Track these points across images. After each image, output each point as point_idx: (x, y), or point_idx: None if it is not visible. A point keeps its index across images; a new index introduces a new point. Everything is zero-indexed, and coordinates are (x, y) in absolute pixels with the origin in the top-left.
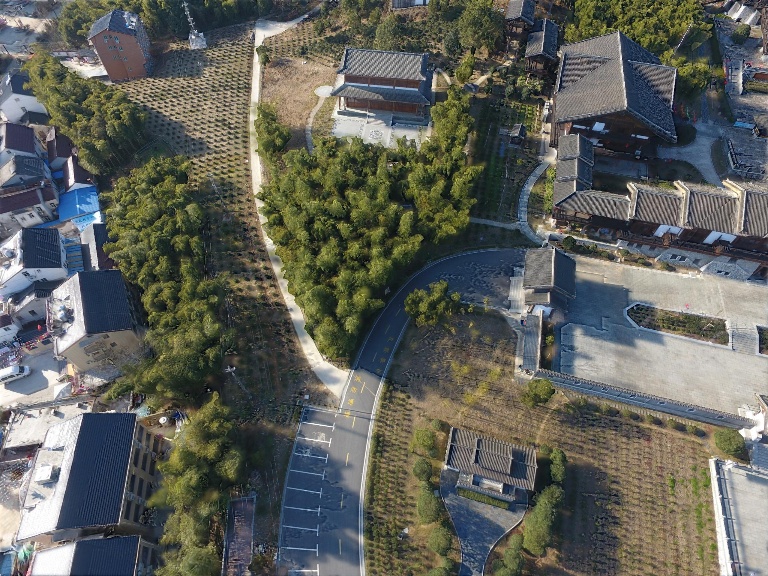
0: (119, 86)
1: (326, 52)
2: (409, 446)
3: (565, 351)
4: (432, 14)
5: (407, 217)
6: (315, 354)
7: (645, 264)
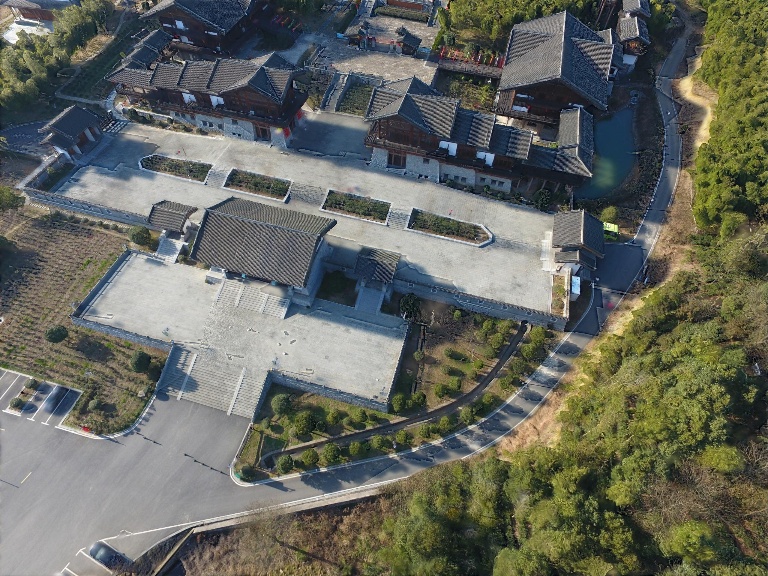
0: None
1: None
2: None
3: (69, 182)
4: None
5: None
6: None
7: (187, 130)
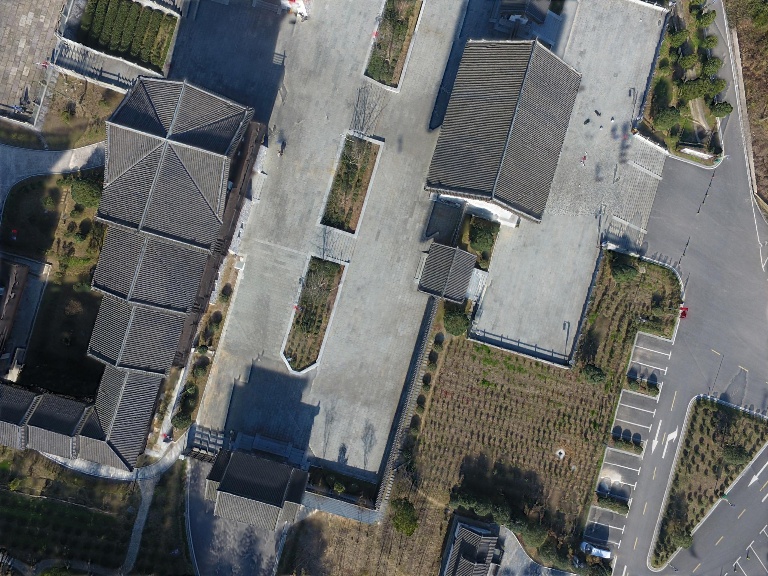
0: None
1: None
2: None
3: (347, 460)
4: None
5: None
6: None
7: (218, 320)
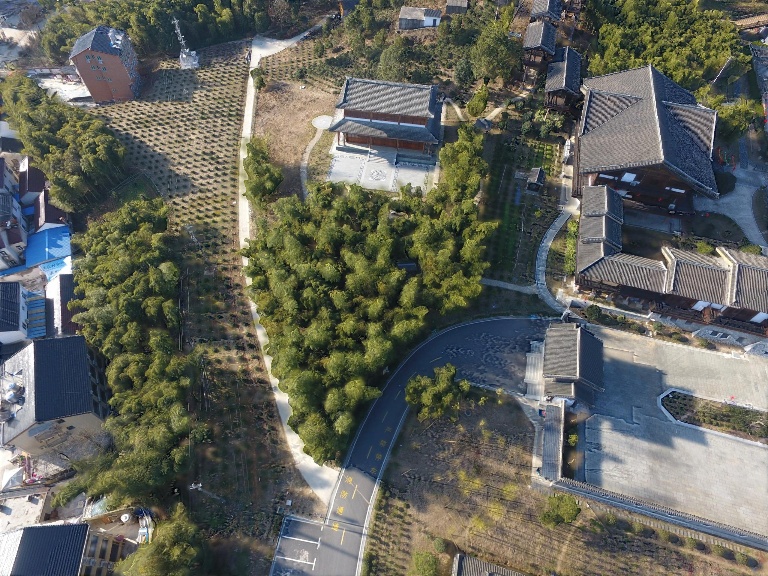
0: (102, 110)
1: (326, 76)
2: (407, 572)
3: (590, 451)
4: (442, 37)
5: (410, 289)
6: (301, 446)
7: (680, 339)
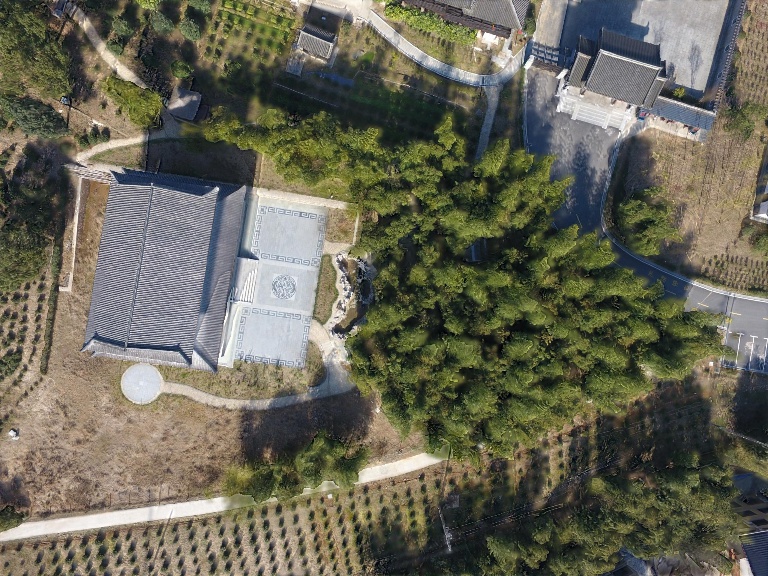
0: None
1: None
2: (761, 259)
3: (675, 79)
4: None
5: (575, 244)
6: None
7: None
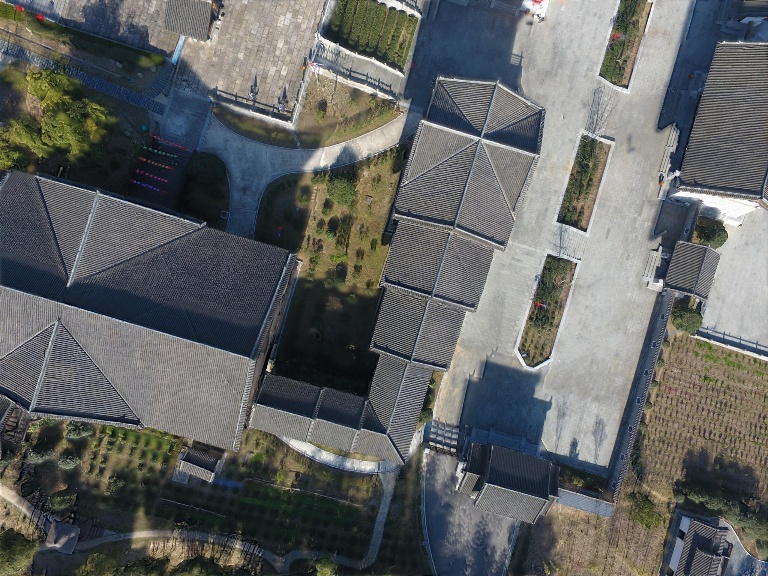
0: None
1: None
2: None
3: (578, 455)
4: None
5: None
6: None
7: None
